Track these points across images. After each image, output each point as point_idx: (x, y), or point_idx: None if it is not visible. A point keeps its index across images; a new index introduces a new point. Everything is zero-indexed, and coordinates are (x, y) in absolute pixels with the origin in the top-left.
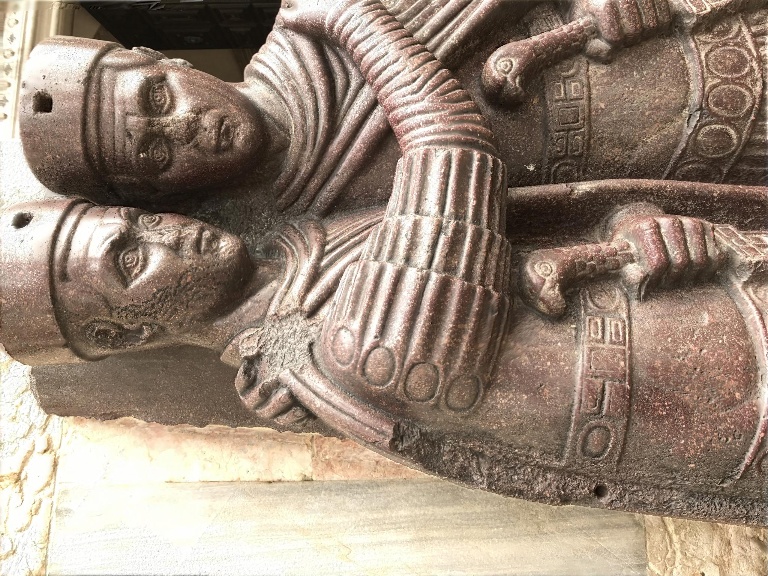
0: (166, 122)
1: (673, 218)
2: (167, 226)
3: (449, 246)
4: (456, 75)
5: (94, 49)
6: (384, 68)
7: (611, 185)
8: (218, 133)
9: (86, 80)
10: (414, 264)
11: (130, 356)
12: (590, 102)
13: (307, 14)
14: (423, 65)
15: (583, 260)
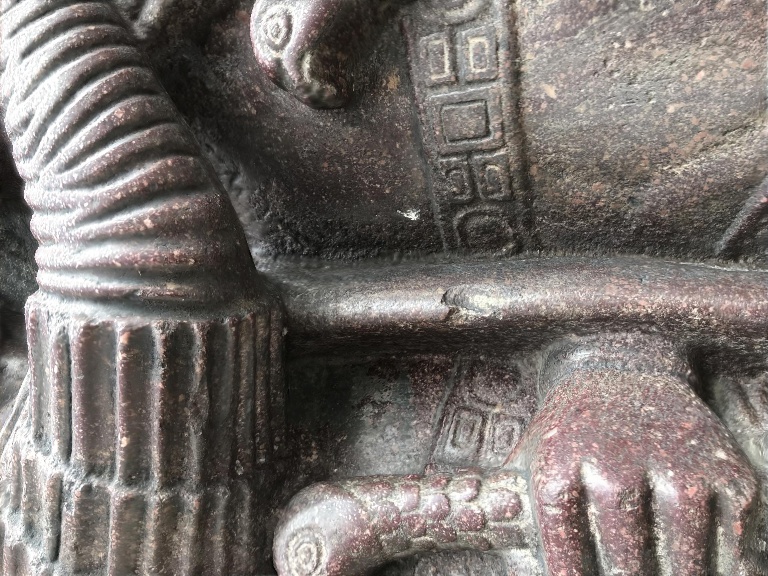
0: None
1: (624, 486)
2: None
3: (76, 531)
4: (234, 24)
5: None
6: None
7: (543, 305)
8: None
9: None
10: (38, 540)
11: None
12: (519, 84)
13: None
14: (44, 81)
15: (402, 535)
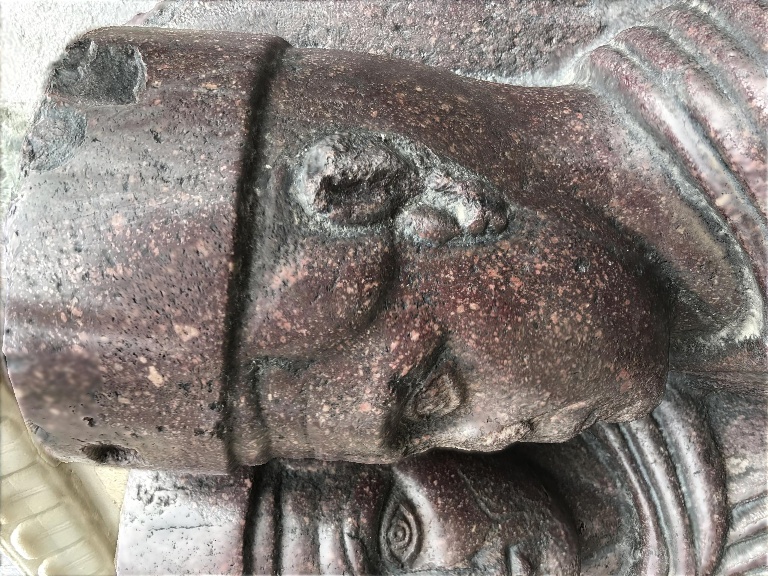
0: (447, 441)
1: None
2: (443, 568)
3: None
4: None
5: (208, 313)
6: None
7: None
8: (574, 436)
9: (220, 422)
10: None
11: None
12: None
13: None
14: None
15: None
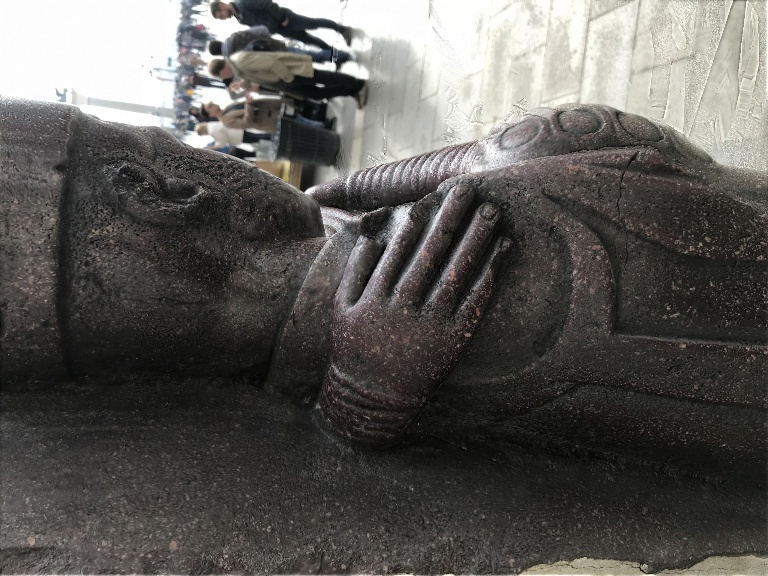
0: None
1: None
2: None
3: None
4: None
5: None
6: (421, 156)
7: None
8: None
9: None
10: None
11: (60, 421)
12: None
13: (327, 184)
14: None
15: None
